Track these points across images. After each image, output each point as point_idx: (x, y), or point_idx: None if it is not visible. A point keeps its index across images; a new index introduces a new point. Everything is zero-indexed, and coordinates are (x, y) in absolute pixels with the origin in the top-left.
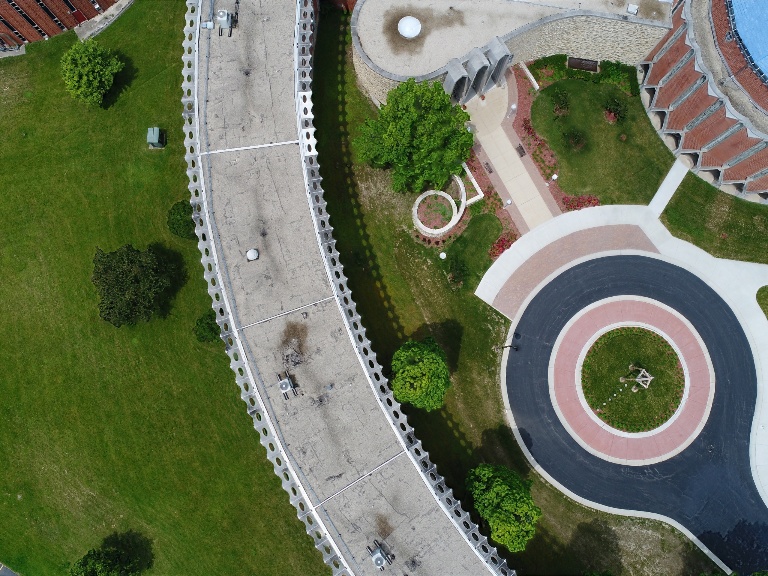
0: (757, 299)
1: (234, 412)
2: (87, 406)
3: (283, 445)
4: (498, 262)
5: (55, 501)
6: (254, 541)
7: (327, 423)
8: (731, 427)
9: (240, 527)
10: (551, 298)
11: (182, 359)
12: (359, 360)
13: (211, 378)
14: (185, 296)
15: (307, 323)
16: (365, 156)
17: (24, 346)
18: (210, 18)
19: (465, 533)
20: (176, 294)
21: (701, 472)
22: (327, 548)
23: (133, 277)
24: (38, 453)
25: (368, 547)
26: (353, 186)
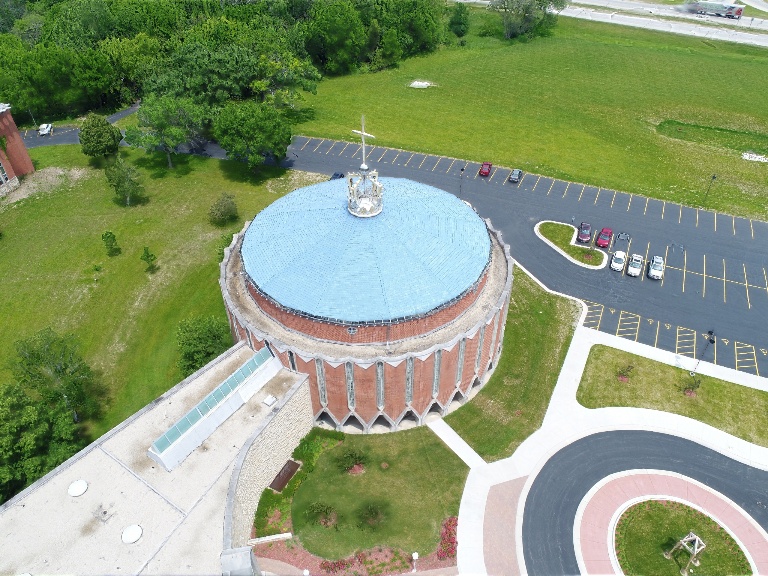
0: (589, 408)
1: None
2: None
3: None
4: None
5: None
6: None
7: None
8: (733, 477)
9: None
10: None
11: None
12: None
13: None
14: None
15: None
16: None
17: None
18: None
19: None
20: None
21: None
22: None
23: None
24: None
25: None
26: None
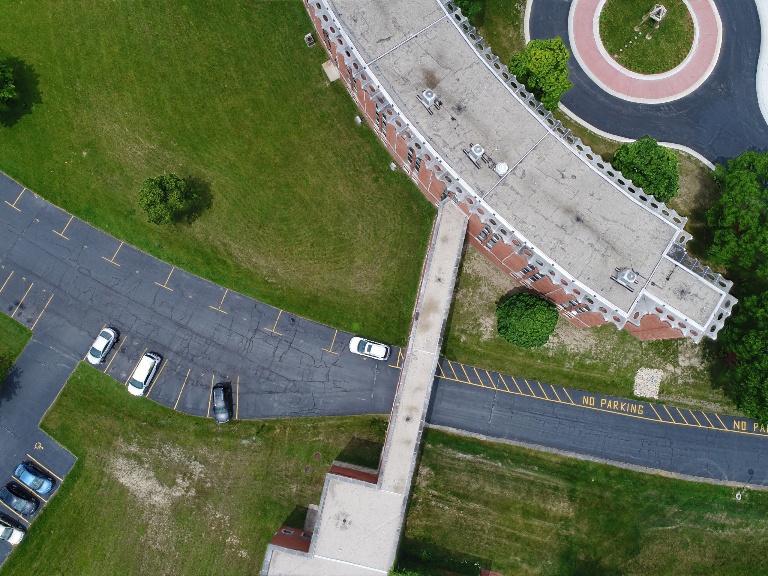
0: None
1: (281, 59)
2: (143, 70)
3: (336, 15)
4: None
5: (118, 156)
6: (305, 173)
7: None
8: (739, 68)
9: (292, 161)
10: None
11: (230, 18)
12: None
13: (258, 32)
14: None
15: None
16: None
17: (81, 23)
18: None
19: (504, 82)
20: None
21: (713, 107)
22: (380, 99)
23: None
24: (100, 115)
25: (418, 96)
26: None
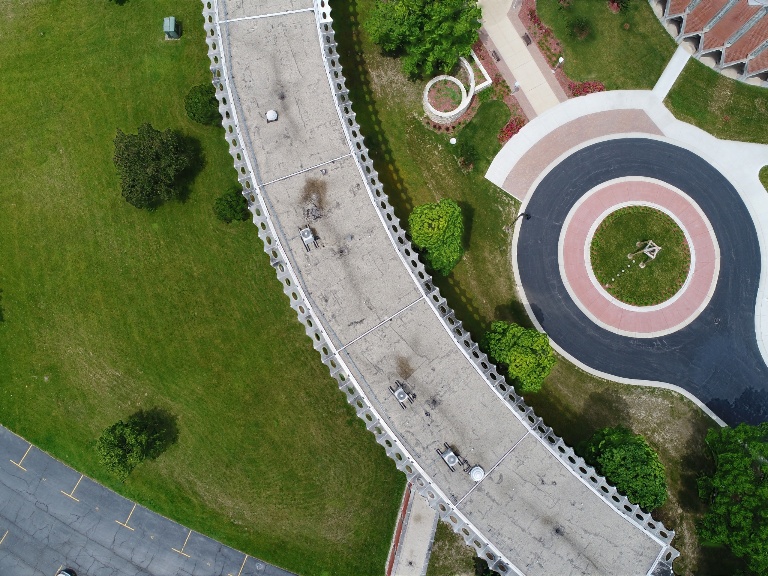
0: (759, 178)
1: (254, 289)
2: (110, 290)
3: (306, 294)
4: (507, 146)
5: (81, 382)
6: (276, 412)
7: (348, 273)
8: (736, 300)
9: (262, 400)
10: (559, 180)
11: (202, 241)
12: (377, 213)
13: (231, 258)
14: (203, 180)
15: (326, 179)
16: (377, 34)
17: (47, 235)
18: None
19: (483, 373)
20: (195, 179)
21: (708, 343)
22: (350, 389)
23: (154, 153)
24: (63, 337)
25: (390, 387)
26: (364, 73)
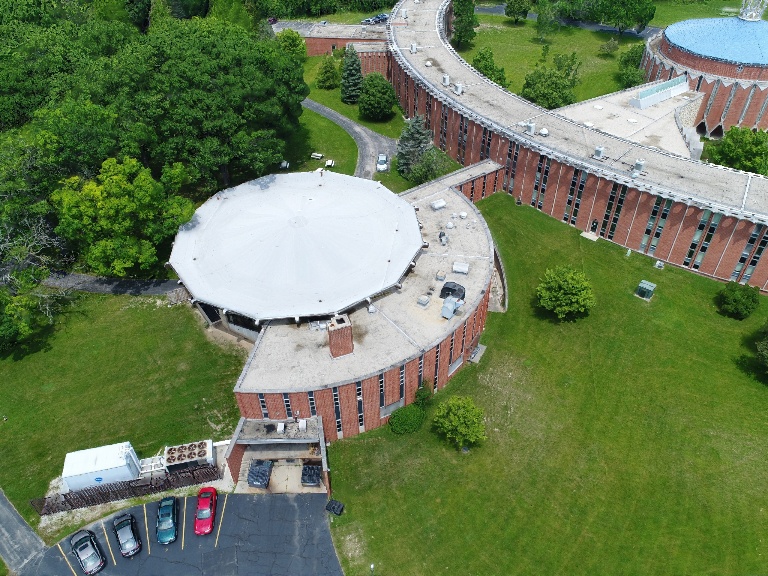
0: None
1: None
2: None
3: None
4: None
5: None
6: None
7: None
8: None
9: None
10: None
11: None
12: None
13: None
14: None
15: None
16: None
17: None
18: (629, 174)
19: None
20: None
21: None
22: None
23: None
24: None
25: None
26: None
